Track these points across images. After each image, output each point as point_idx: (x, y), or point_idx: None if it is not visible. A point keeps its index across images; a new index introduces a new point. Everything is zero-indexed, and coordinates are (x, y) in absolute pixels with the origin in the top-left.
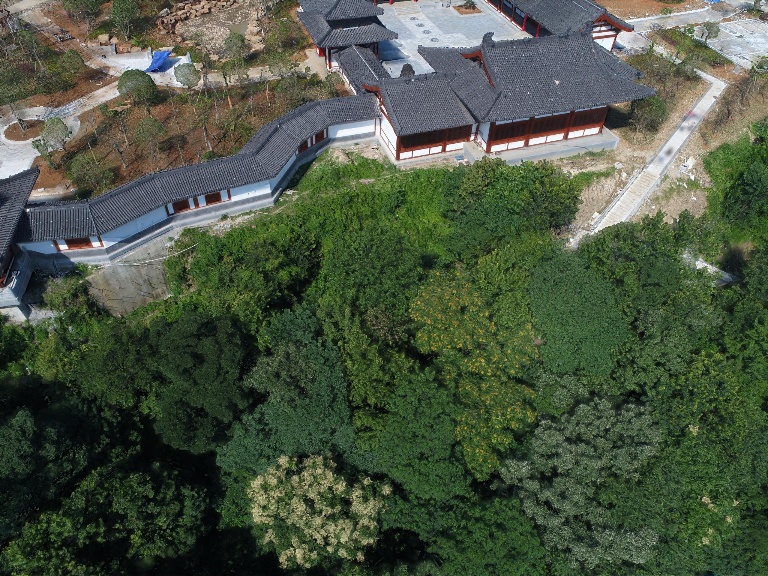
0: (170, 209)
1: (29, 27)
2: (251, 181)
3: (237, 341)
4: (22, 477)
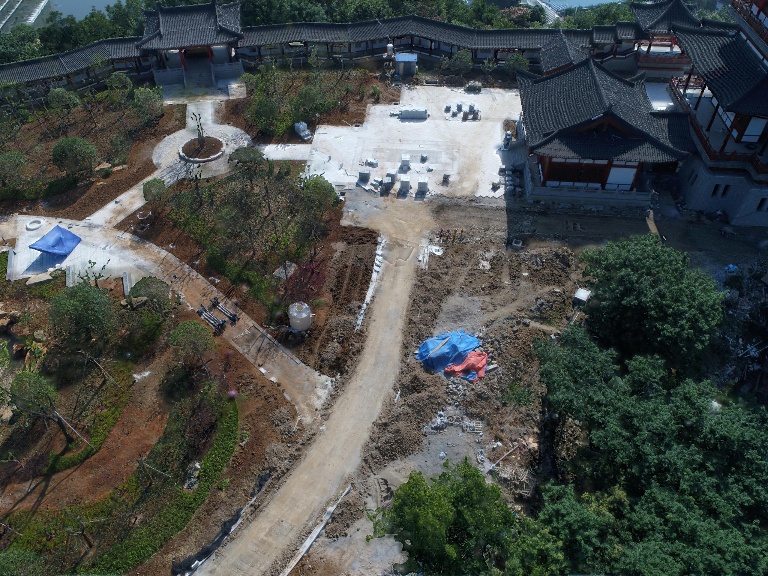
0: None
1: (287, 336)
2: None
3: None
4: None
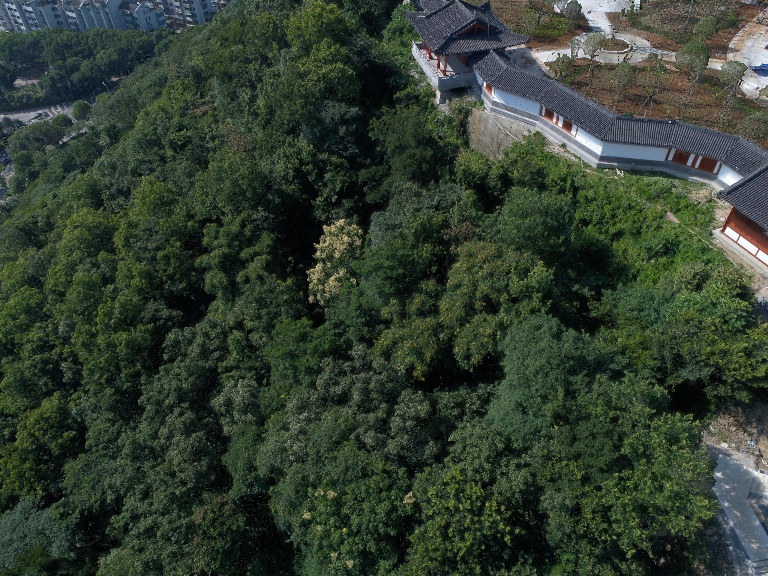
0: (543, 111)
1: (762, 5)
2: (587, 129)
3: (424, 167)
4: (325, 125)
